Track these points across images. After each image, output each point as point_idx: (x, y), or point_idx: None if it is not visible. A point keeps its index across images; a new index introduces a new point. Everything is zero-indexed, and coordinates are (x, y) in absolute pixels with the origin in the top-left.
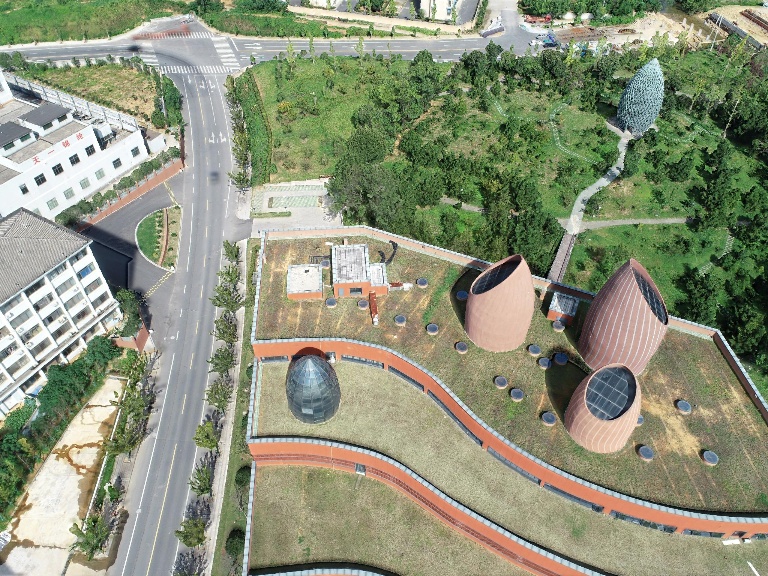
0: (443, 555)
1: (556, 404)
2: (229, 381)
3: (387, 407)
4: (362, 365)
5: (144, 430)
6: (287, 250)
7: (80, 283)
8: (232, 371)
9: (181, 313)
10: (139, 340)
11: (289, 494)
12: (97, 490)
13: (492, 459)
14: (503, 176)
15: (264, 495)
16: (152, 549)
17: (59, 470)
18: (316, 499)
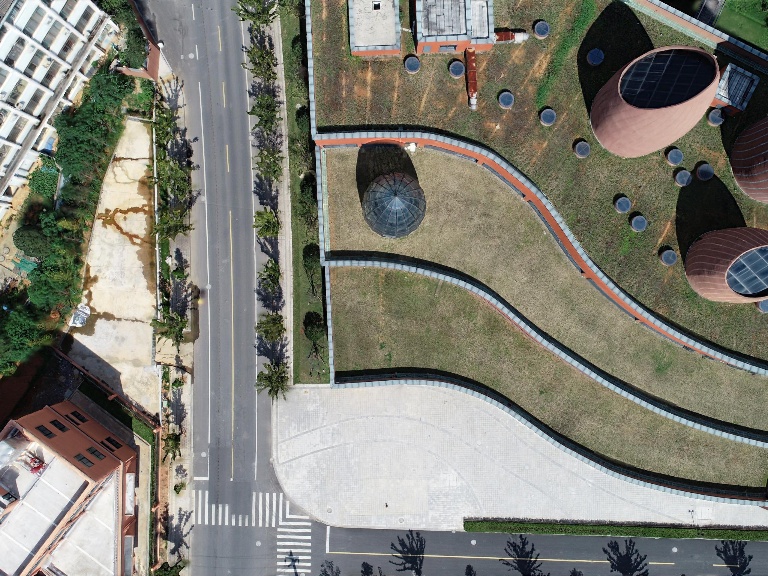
0: (520, 365)
1: (682, 236)
2: (276, 128)
3: (478, 218)
4: (450, 156)
5: (190, 192)
6: None
7: (51, 10)
8: (277, 113)
9: (193, 13)
10: (151, 67)
11: (367, 299)
12: (159, 263)
13: (590, 288)
14: None
15: (341, 299)
16: (232, 325)
17: (111, 239)
18: (395, 305)
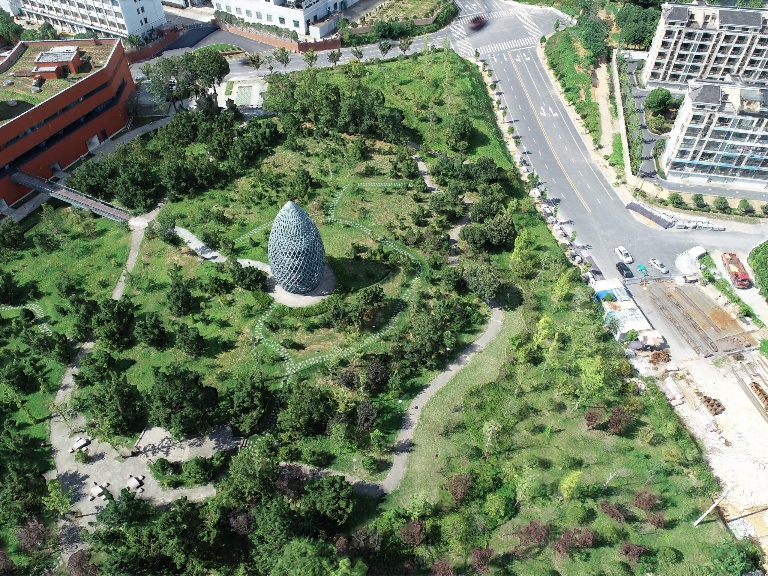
0: None
1: None
2: None
3: None
4: None
5: None
6: (103, 50)
7: (112, 6)
8: None
9: (141, 71)
10: None
11: None
12: None
13: None
14: (193, 157)
15: None
16: None
17: None
18: None
